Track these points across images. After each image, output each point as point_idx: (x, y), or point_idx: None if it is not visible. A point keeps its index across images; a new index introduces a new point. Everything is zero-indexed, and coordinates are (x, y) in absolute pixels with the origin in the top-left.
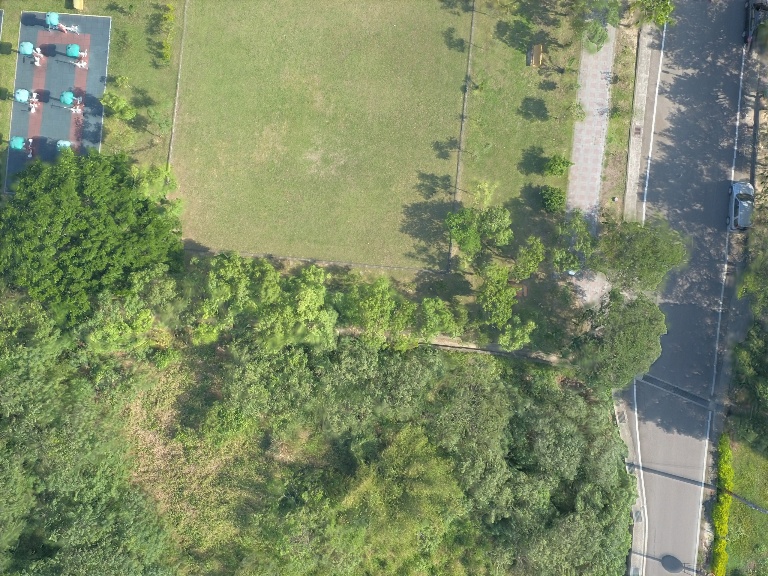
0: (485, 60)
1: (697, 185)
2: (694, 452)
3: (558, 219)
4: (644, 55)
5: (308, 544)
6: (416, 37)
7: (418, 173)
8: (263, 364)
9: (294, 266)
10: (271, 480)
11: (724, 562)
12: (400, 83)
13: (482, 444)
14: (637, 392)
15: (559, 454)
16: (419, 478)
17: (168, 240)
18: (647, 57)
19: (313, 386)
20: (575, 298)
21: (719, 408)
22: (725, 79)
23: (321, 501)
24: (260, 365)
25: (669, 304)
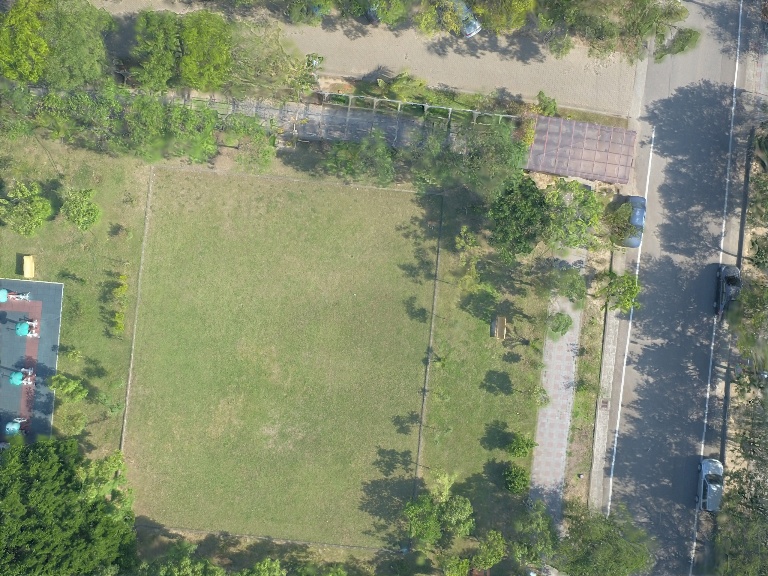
0: (448, 331)
1: (665, 460)
2: None
3: (522, 496)
4: (612, 325)
5: None
6: (377, 307)
7: (378, 449)
8: None
9: (251, 543)
10: None
11: None
12: (360, 355)
13: None
14: None
15: None
16: None
17: (119, 532)
18: (615, 328)
19: None
20: None
21: None
22: (695, 350)
23: None
24: None
25: None
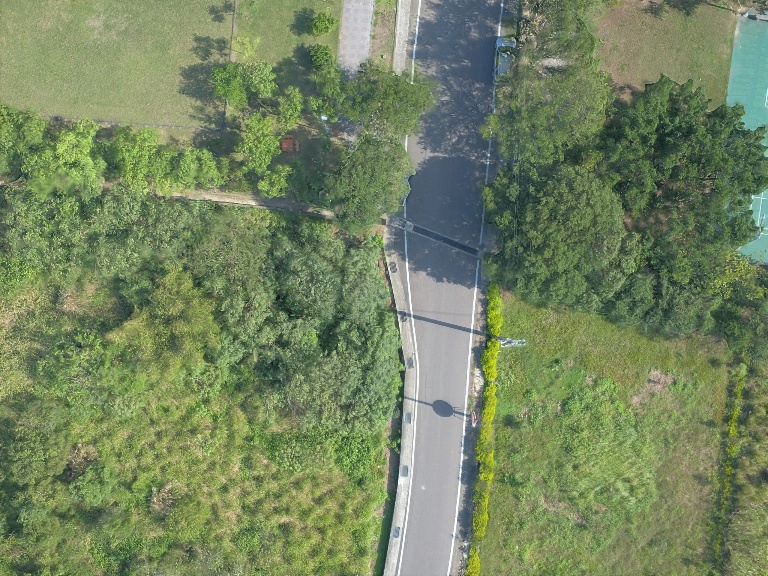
0: None
1: (465, 41)
2: (463, 299)
3: None
4: None
5: (82, 384)
6: None
7: (195, 36)
8: (34, 211)
9: None
10: (60, 332)
11: (491, 404)
12: None
13: (248, 288)
14: (408, 243)
15: (311, 291)
16: (179, 316)
17: None
18: None
19: (83, 233)
20: (347, 153)
21: (487, 256)
22: None
23: (92, 342)
24: (31, 212)
25: (438, 157)
